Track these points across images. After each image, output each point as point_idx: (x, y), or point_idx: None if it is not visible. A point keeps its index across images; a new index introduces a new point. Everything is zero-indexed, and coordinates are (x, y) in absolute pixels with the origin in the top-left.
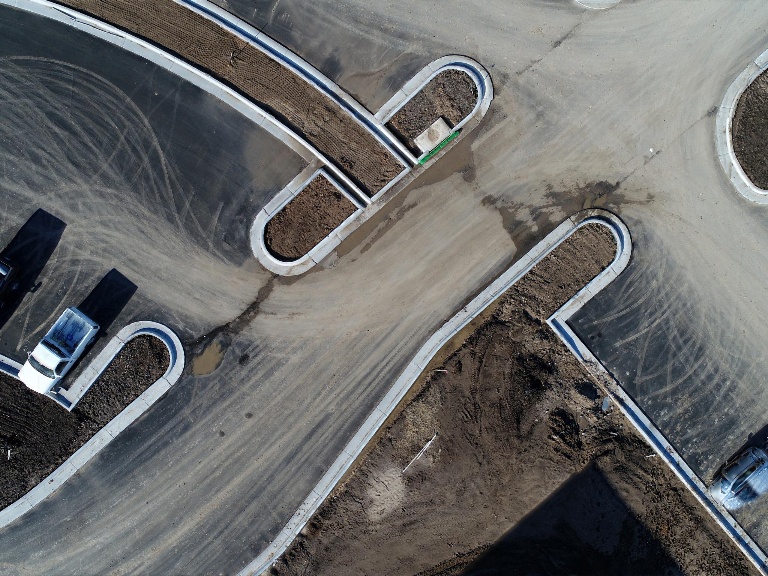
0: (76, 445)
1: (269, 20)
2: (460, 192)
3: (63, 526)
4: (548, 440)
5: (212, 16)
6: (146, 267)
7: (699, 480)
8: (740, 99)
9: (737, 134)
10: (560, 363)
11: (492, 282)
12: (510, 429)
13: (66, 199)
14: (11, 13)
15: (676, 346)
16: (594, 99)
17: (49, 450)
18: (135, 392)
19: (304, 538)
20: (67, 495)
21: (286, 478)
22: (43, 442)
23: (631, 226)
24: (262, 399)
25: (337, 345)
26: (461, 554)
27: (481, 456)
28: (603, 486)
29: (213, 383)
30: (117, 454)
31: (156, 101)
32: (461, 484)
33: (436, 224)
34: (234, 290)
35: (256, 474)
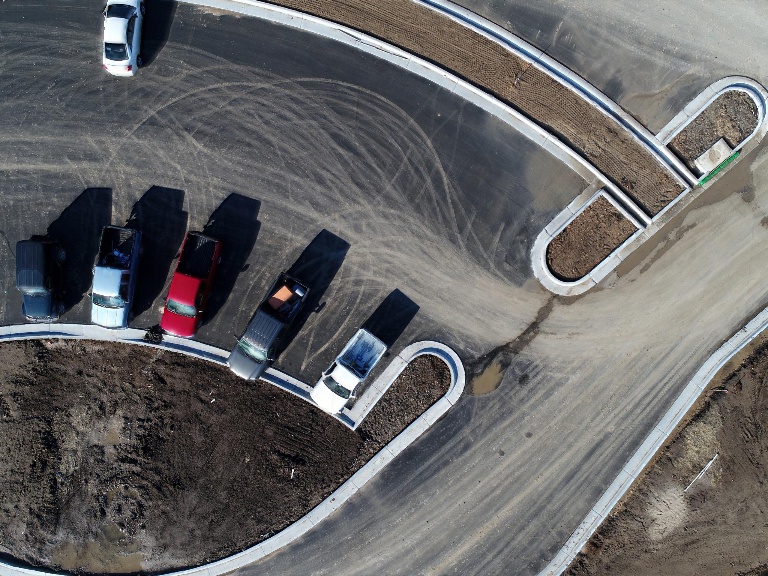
0: (357, 464)
1: (552, 41)
2: (739, 212)
3: (344, 544)
4: None
5: (497, 37)
6: (428, 287)
7: None
8: None
9: None
10: None
11: None
12: None
13: (350, 220)
14: (296, 35)
15: None
16: None
17: (331, 469)
18: (416, 411)
19: (584, 557)
20: (348, 514)
21: (565, 497)
22: (326, 461)
23: None
24: (542, 418)
25: (616, 365)
26: (743, 573)
27: (762, 476)
28: None
29: (493, 402)
30: (398, 473)
31: (439, 122)
32: (742, 503)
33: (715, 244)
34: (514, 310)
35: (536, 493)
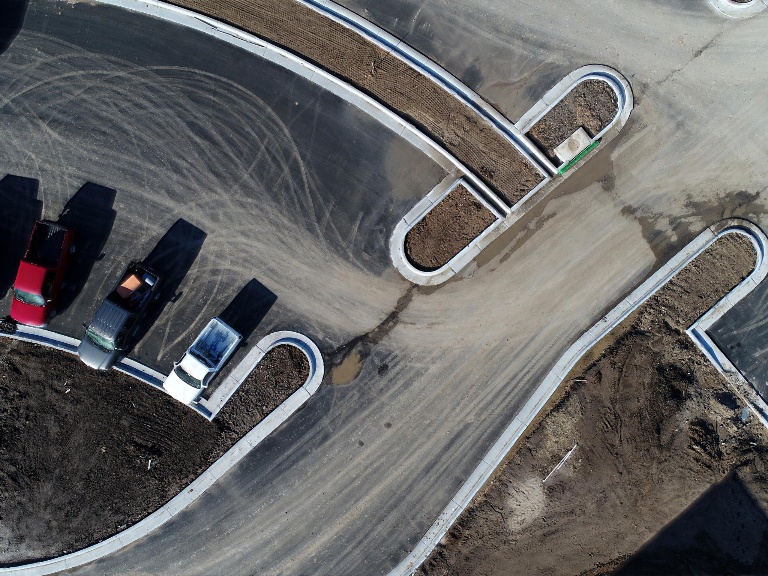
0: (215, 455)
1: (410, 29)
2: (599, 202)
3: (202, 536)
4: (688, 450)
5: (353, 25)
6: (286, 277)
7: None
8: None
9: None
10: (699, 373)
11: (631, 292)
12: (650, 439)
13: (207, 209)
14: (152, 23)
15: None
16: (735, 108)
17: (189, 460)
18: (274, 402)
19: (443, 548)
20: (206, 505)
21: (425, 488)
22: (183, 452)
23: None
24: (401, 409)
25: (476, 355)
26: (601, 564)
27: (621, 466)
28: (743, 496)
29: (352, 393)
30: (256, 464)
31: (296, 111)
32: (601, 494)
33: (575, 234)
34: (373, 300)
35: (395, 484)
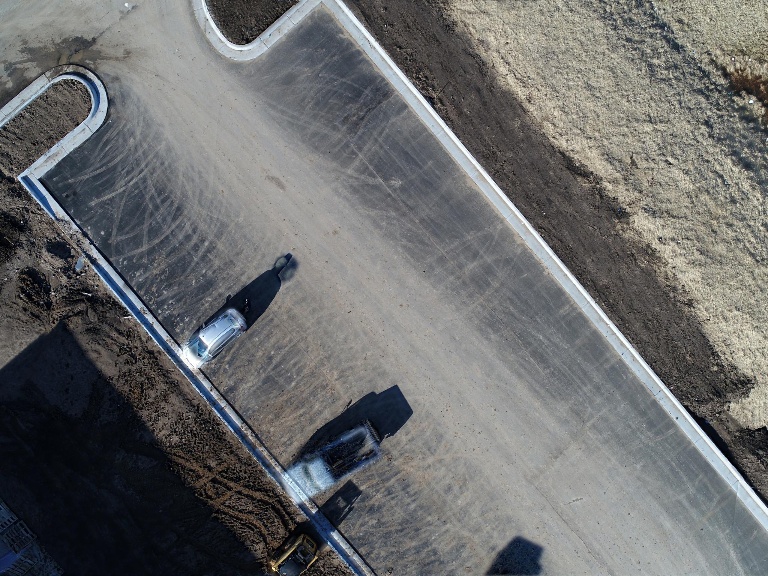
0: None
1: None
2: None
3: None
4: (17, 299)
5: None
6: None
7: (174, 342)
8: None
9: None
10: (34, 222)
11: None
12: None
13: None
14: None
15: (153, 206)
16: None
17: None
18: None
19: None
20: None
21: None
22: None
23: (107, 83)
24: None
25: None
26: None
27: None
28: (73, 347)
29: None
30: None
31: None
32: None
33: None
34: None
35: None
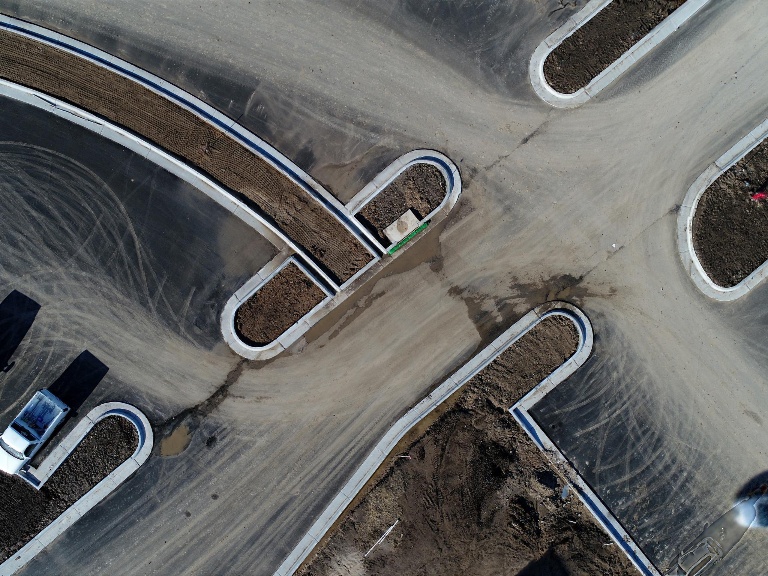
0: (44, 522)
1: (244, 111)
2: (427, 282)
3: None
4: (508, 527)
5: (189, 106)
6: (118, 349)
7: (655, 569)
8: (701, 199)
9: (697, 233)
10: (521, 451)
11: (456, 371)
12: (471, 516)
13: (41, 281)
14: None
15: (635, 437)
16: (559, 195)
17: (17, 527)
18: (104, 471)
19: None
20: (34, 572)
21: (250, 559)
22: (11, 519)
23: (593, 319)
24: (228, 481)
25: (303, 429)
26: None
27: (442, 542)
28: (561, 574)
29: (181, 464)
30: (84, 532)
31: (132, 187)
32: (422, 569)
33: (403, 313)
34: (204, 373)
35: (221, 555)
